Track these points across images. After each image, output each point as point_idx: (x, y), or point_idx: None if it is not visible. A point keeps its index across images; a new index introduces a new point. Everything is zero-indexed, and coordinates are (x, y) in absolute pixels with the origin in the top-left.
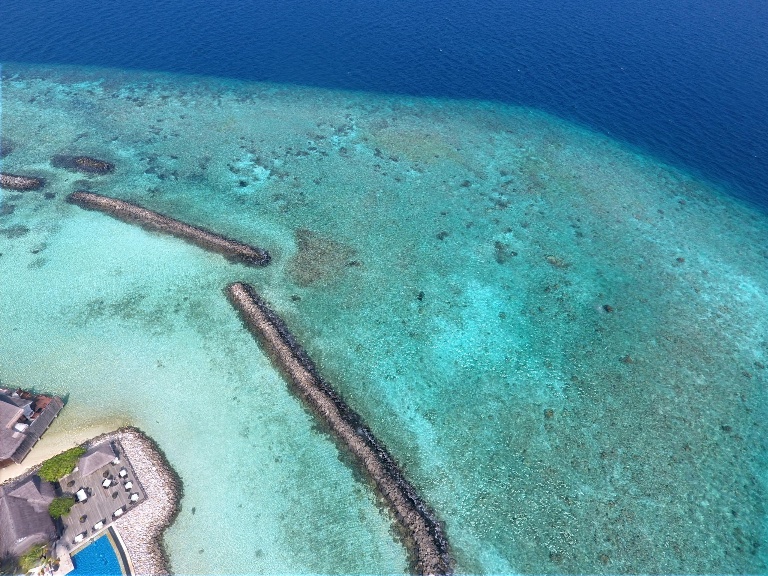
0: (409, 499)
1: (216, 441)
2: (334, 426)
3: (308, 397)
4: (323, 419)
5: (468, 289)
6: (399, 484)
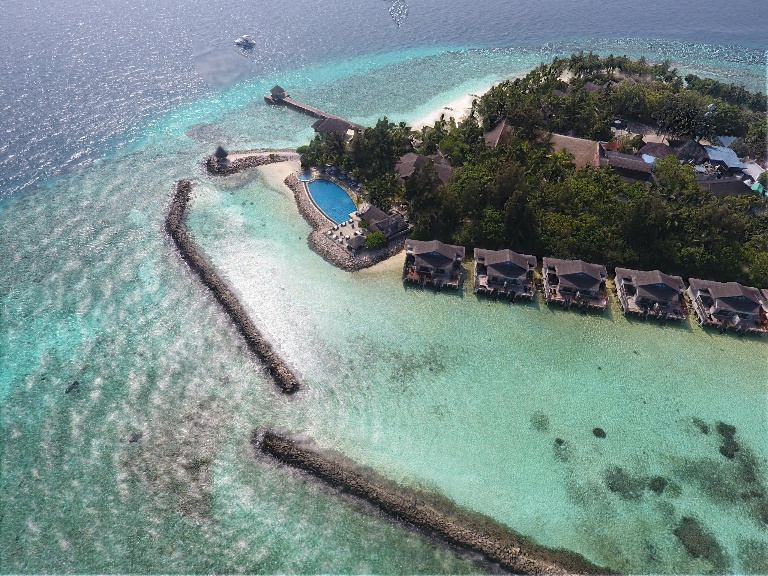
0: (174, 237)
1: (293, 265)
2: (210, 268)
3: (226, 286)
4: (217, 275)
5: (2, 399)
6: (177, 243)
